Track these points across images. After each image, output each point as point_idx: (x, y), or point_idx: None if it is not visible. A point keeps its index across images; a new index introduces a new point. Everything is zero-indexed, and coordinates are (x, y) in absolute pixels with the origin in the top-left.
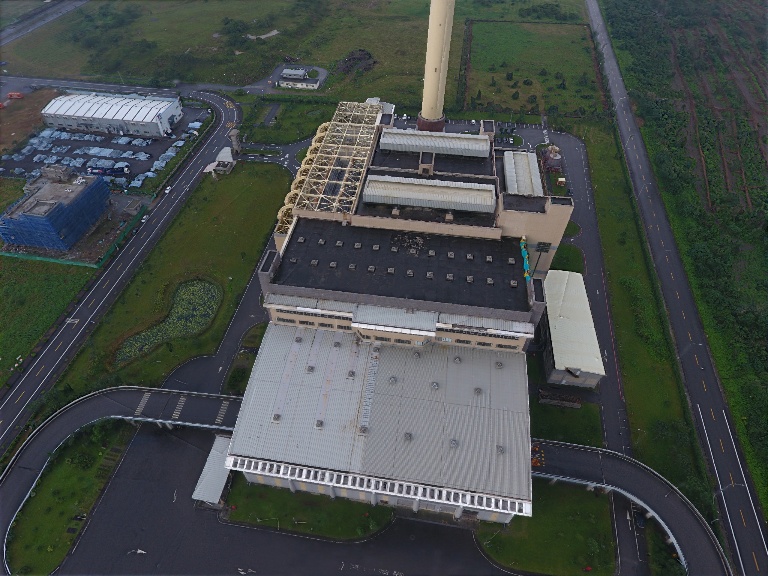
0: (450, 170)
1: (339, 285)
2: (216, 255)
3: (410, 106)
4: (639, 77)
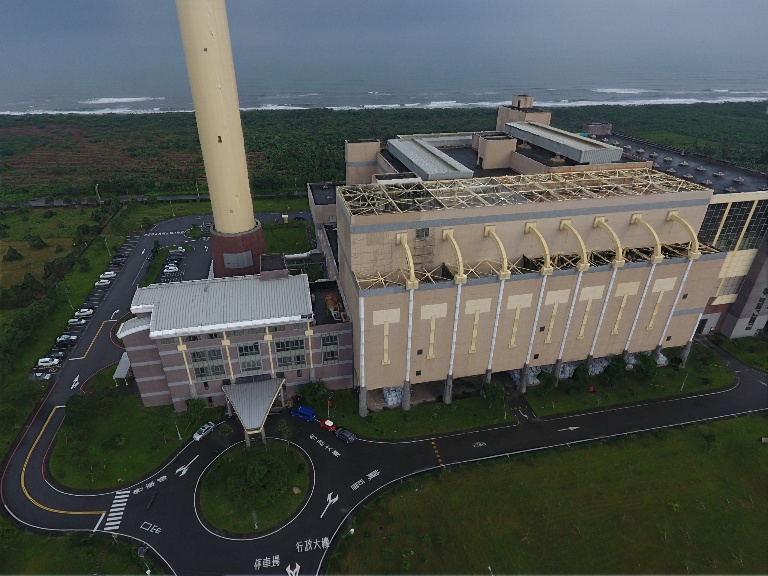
0: (463, 161)
1: (732, 171)
2: (763, 512)
3: (14, 349)
4: (7, 191)
